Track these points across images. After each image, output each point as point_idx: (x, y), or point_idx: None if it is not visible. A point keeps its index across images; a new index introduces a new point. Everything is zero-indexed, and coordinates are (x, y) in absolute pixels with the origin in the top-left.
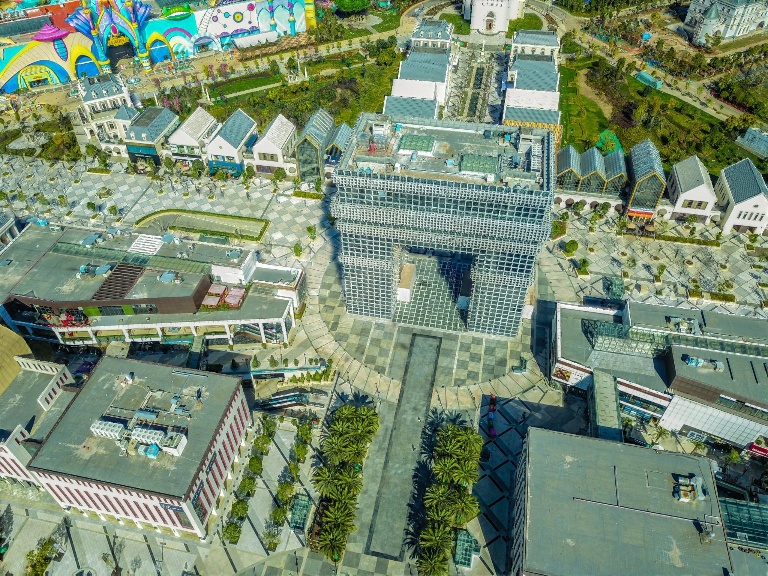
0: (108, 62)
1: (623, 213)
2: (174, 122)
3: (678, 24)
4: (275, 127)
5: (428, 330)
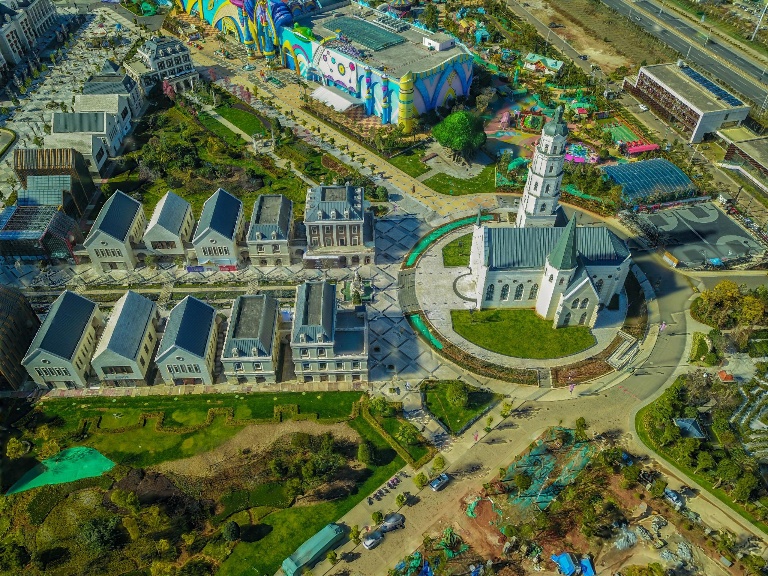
0: (248, 43)
1: None
2: None
3: None
4: (68, 138)
5: None
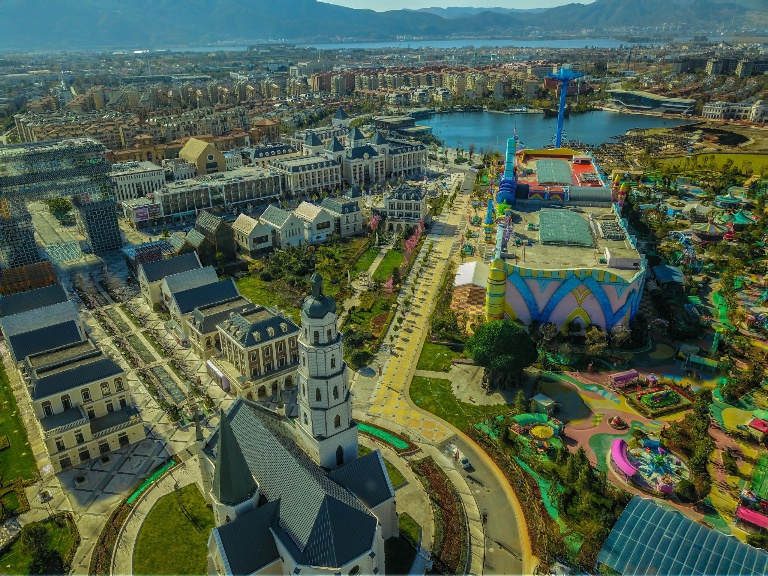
0: None
1: None
2: (336, 214)
3: None
4: (248, 219)
5: None
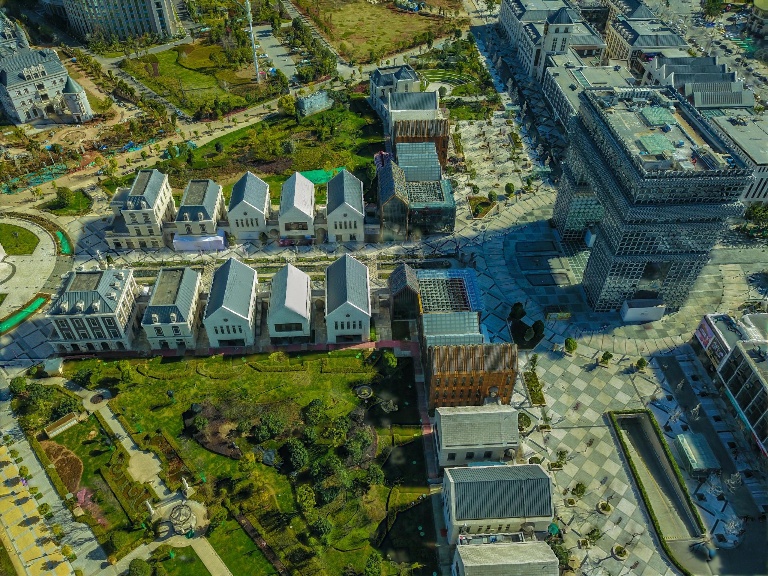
0: None
1: (443, 168)
2: None
3: None
4: None
5: None
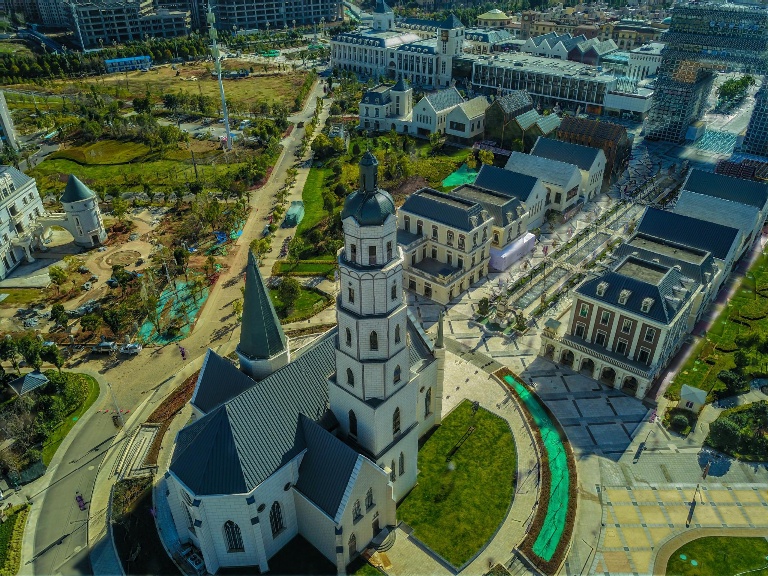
0: None
1: None
2: None
3: (12, 283)
4: None
5: (729, 133)
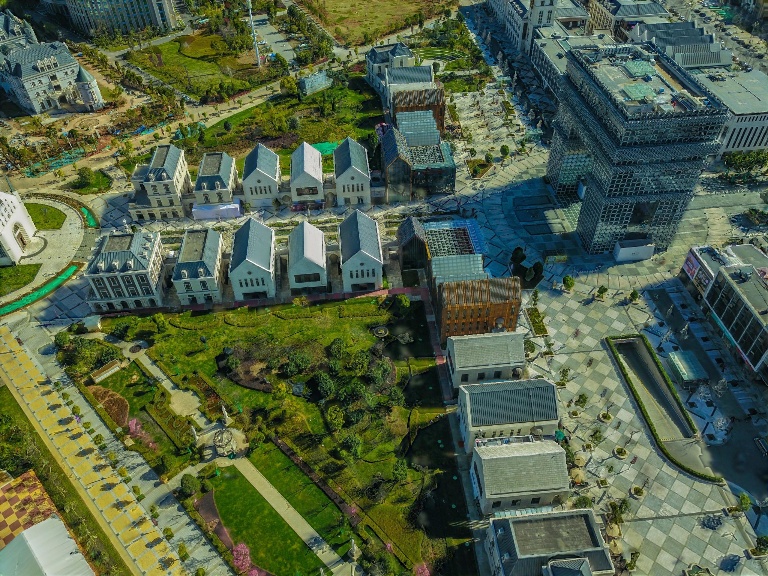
0: None
1: (441, 135)
2: None
3: None
4: None
5: None
